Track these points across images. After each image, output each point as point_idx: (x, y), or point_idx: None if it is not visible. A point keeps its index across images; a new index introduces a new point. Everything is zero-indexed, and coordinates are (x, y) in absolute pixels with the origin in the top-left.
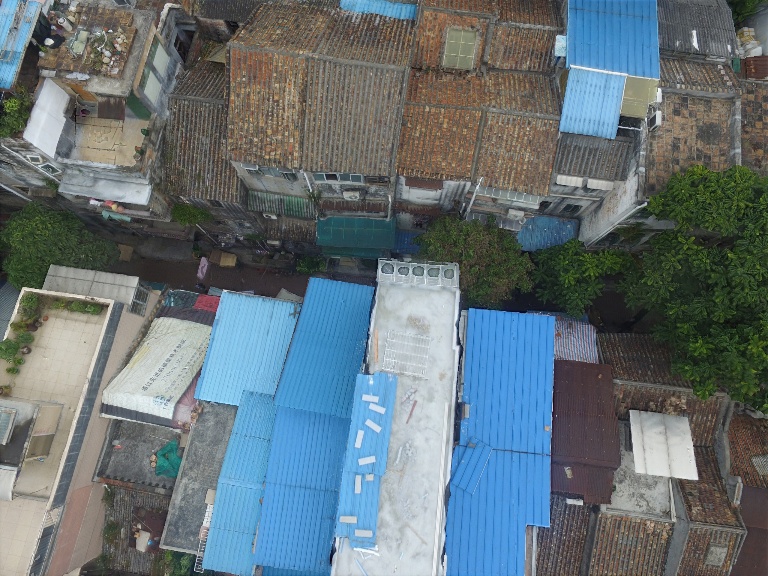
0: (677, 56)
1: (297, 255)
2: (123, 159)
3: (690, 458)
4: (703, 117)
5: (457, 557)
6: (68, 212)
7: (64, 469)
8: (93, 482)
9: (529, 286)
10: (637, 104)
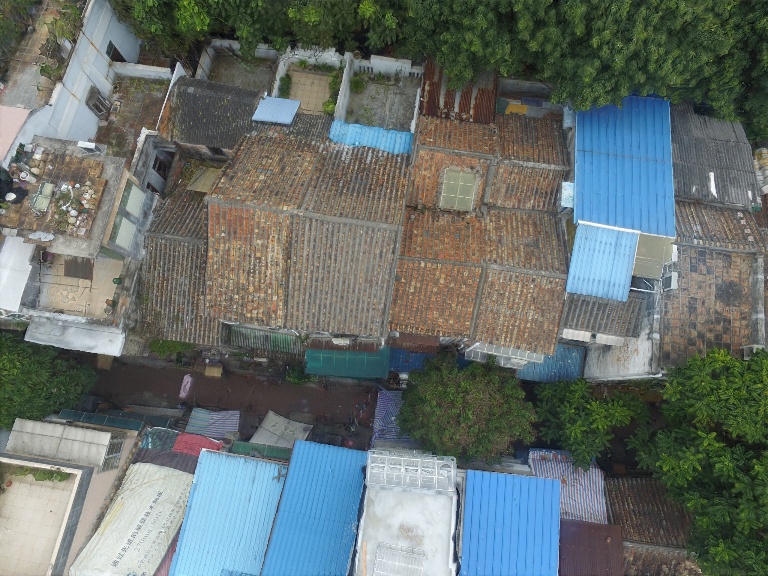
0: (693, 199)
1: None
2: (94, 305)
3: None
4: (722, 274)
5: None
6: None
7: None
8: None
9: (532, 437)
10: (651, 264)
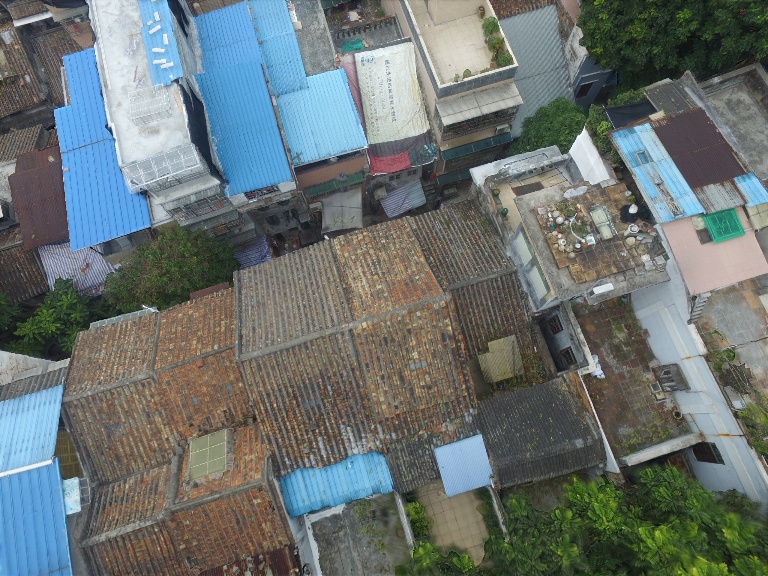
0: None
1: None
2: None
3: None
4: None
5: None
6: None
7: None
8: None
9: (107, 280)
10: None
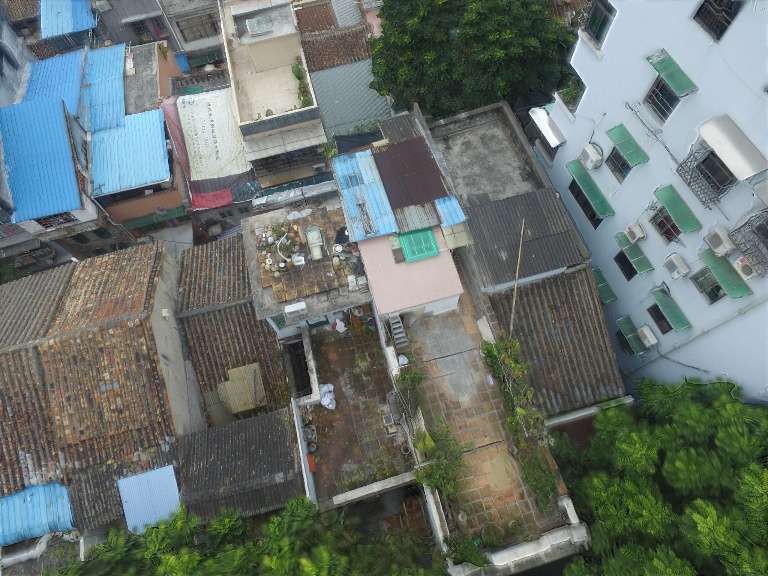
0: None
1: None
2: None
3: None
4: None
5: None
6: None
7: None
8: None
9: None
10: None
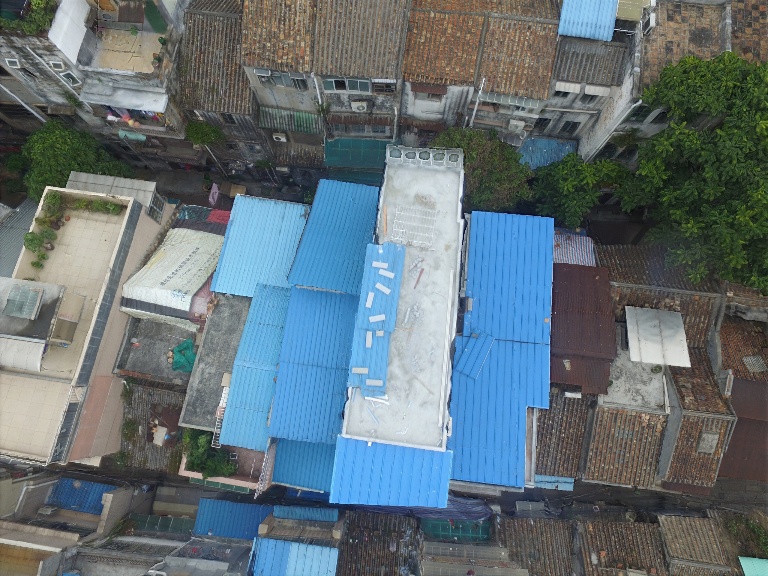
0: None
1: (304, 188)
2: (141, 70)
3: (683, 348)
4: (695, 22)
5: (461, 435)
6: (86, 132)
7: (88, 350)
8: (113, 374)
9: (529, 194)
10: (632, 7)
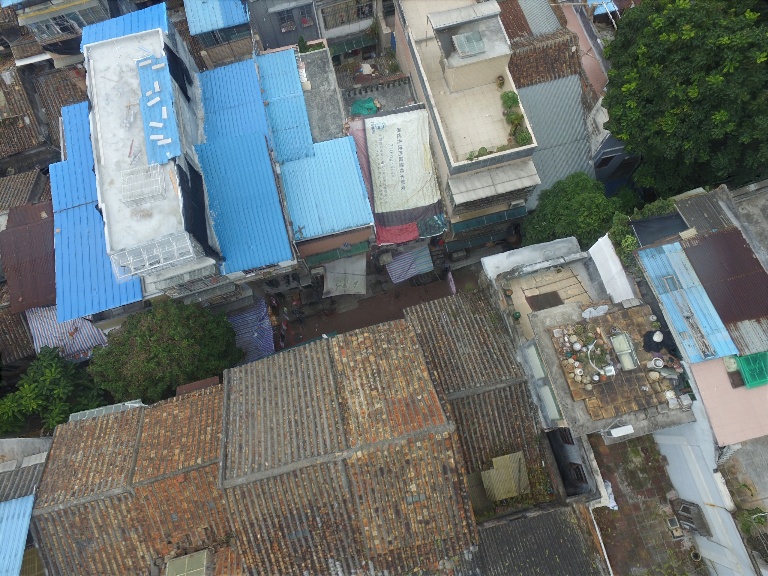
0: None
1: None
2: (531, 290)
3: None
4: None
5: None
6: None
7: None
8: None
9: (93, 353)
10: None
